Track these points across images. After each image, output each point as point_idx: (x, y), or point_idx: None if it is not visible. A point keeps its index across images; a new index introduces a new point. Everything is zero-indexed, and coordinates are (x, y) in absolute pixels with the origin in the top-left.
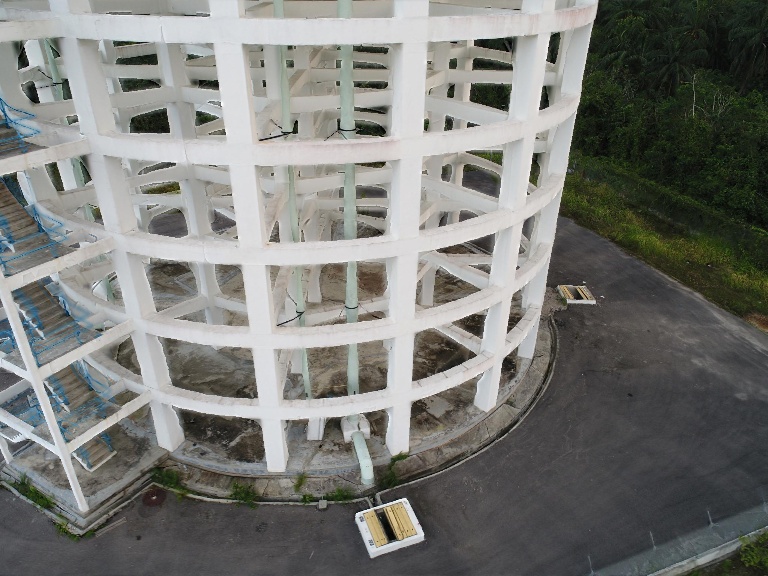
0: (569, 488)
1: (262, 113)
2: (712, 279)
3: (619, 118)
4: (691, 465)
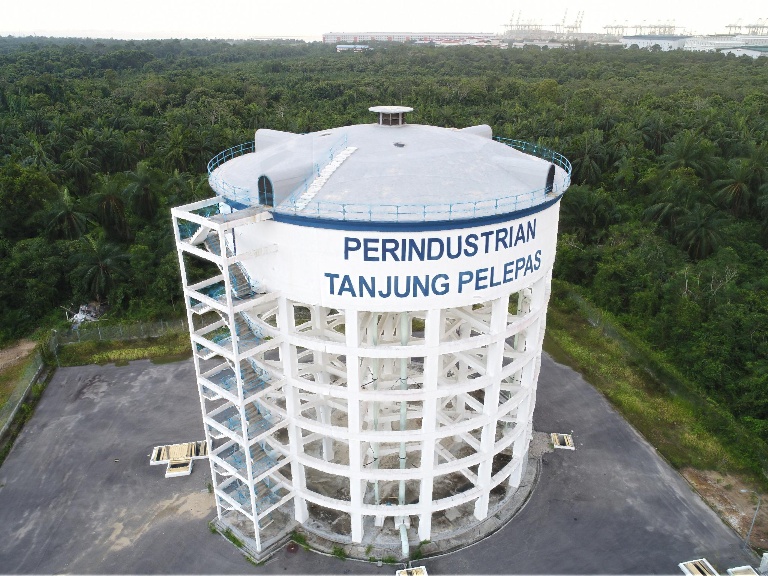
0: (519, 573)
1: (364, 361)
2: (671, 436)
3: (638, 284)
4: (598, 569)
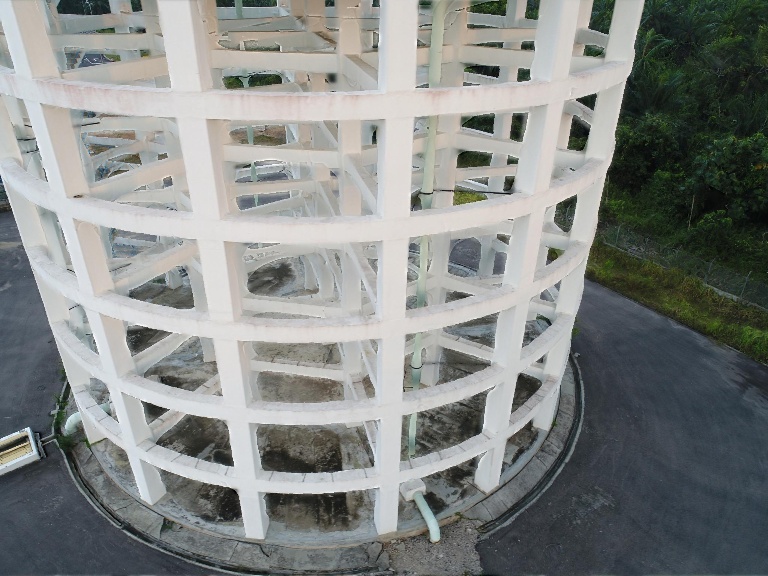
0: None
1: None
2: None
3: None
4: None
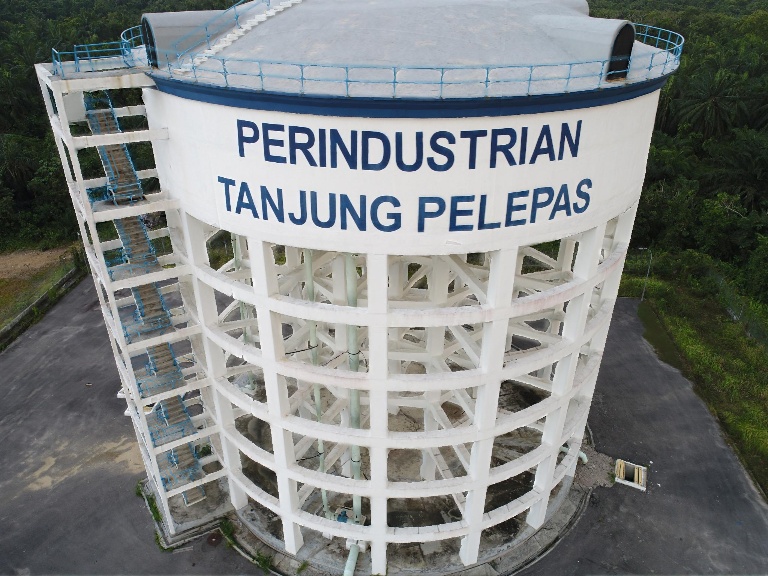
0: None
1: None
2: None
3: None
4: None
